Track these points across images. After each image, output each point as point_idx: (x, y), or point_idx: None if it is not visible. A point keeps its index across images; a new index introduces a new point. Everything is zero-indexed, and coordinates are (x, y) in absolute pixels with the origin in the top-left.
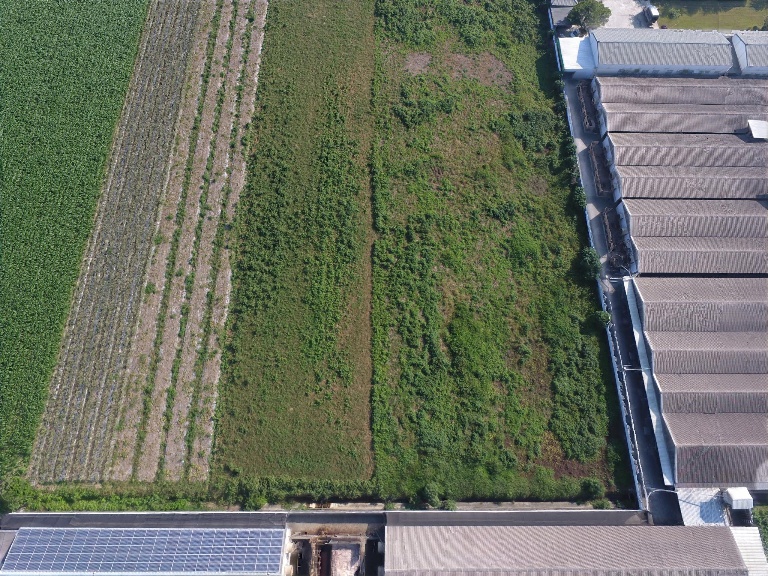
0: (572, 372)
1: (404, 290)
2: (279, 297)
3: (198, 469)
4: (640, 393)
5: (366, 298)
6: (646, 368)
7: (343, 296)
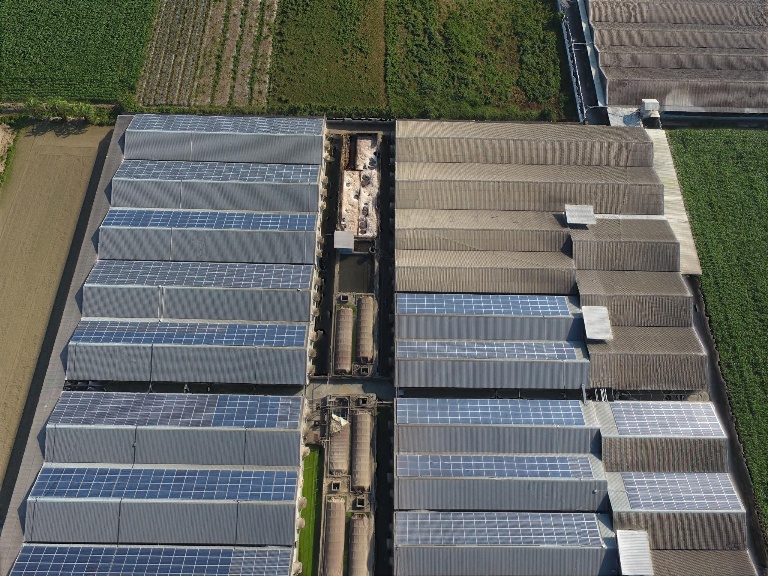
0: (535, 51)
1: (410, 3)
2: (315, 5)
3: (259, 100)
4: (585, 64)
5: (381, 8)
6: (589, 42)
7: (363, 6)
